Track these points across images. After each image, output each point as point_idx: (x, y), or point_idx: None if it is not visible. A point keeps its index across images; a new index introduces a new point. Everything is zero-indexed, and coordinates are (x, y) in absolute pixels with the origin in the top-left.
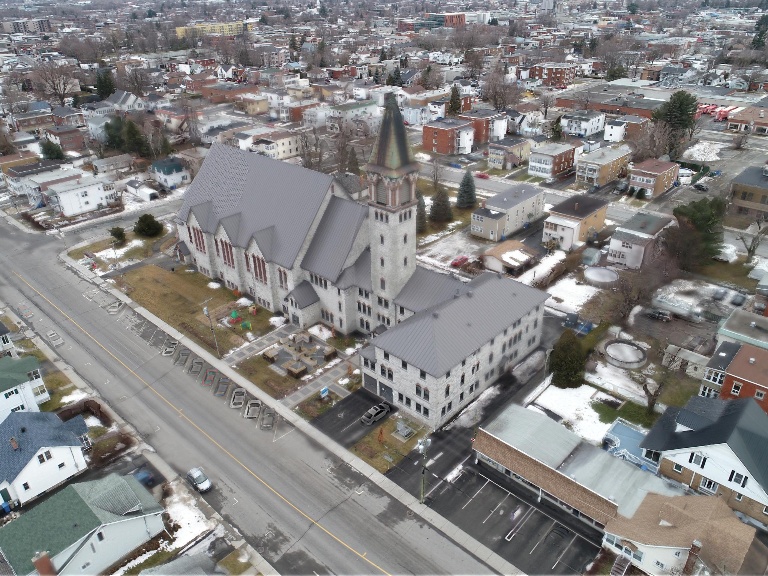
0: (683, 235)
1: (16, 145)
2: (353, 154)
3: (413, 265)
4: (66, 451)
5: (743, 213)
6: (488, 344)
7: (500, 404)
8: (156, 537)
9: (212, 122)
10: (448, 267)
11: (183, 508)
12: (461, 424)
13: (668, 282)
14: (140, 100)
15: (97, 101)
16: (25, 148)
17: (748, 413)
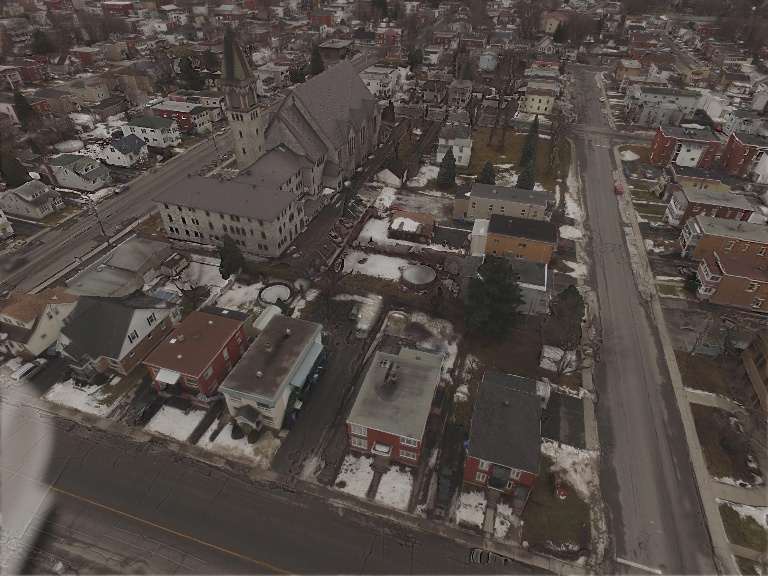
0: (471, 283)
1: (424, 52)
2: (535, 121)
3: (252, 157)
4: (120, 153)
5: (745, 382)
6: (204, 213)
7: (198, 253)
8: (88, 191)
9: (539, 71)
10: (385, 208)
11: (104, 191)
12: (175, 243)
13: (433, 314)
14: (551, 45)
15: (528, 39)
16: (428, 56)
17: (118, 309)
